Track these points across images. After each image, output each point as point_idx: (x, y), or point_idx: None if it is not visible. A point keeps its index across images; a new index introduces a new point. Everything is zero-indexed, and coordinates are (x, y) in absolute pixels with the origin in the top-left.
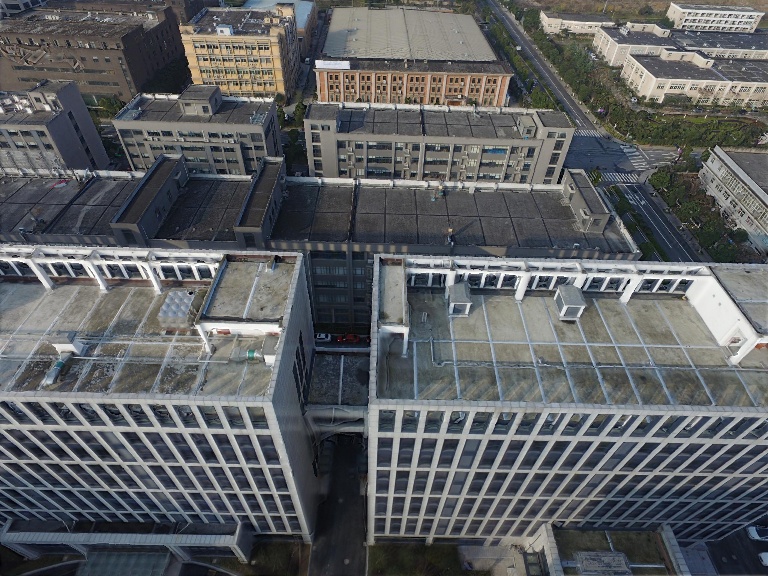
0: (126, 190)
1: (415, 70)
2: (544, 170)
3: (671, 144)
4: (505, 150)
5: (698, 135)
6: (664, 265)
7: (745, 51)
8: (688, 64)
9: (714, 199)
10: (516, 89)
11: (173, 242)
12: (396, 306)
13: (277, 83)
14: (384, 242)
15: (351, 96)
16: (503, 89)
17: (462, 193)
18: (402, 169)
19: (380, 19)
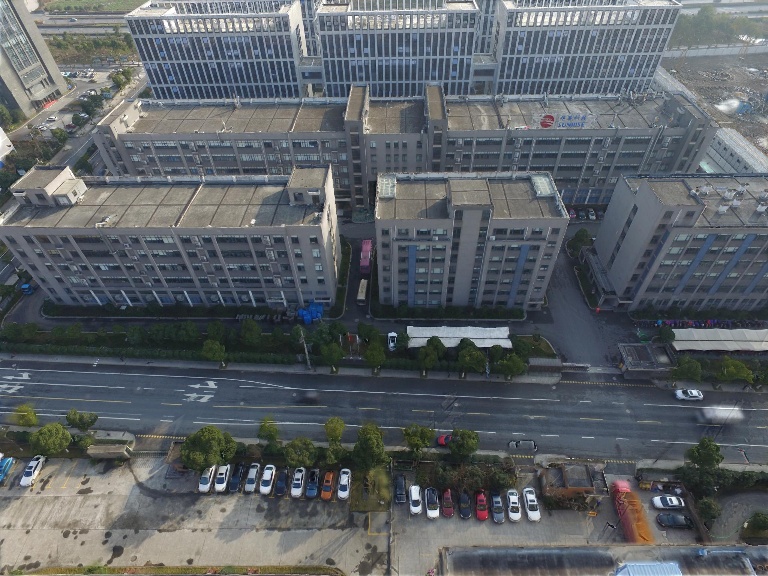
0: (469, 126)
1: None
2: None
3: None
4: None
5: None
6: None
7: None
8: None
9: None
10: None
11: (409, 98)
12: (285, 8)
13: None
14: (280, 106)
15: None
16: None
17: None
18: None
19: None
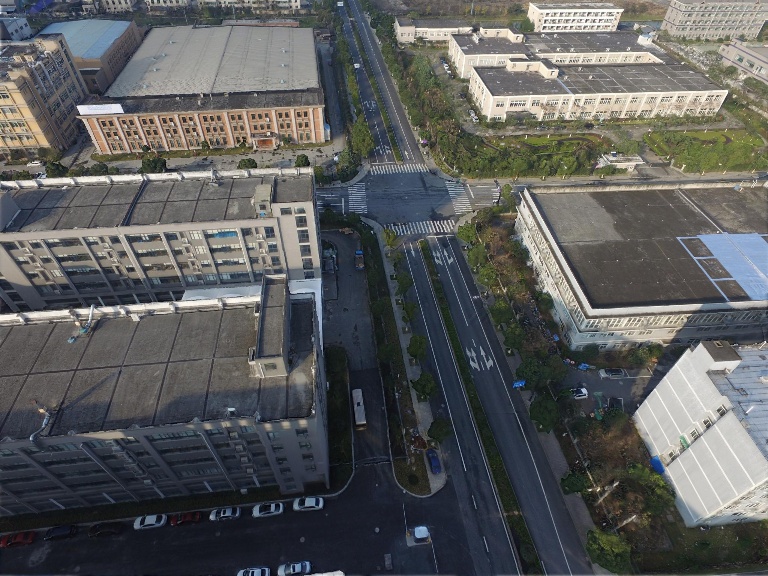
0: None
1: (210, 107)
2: (297, 249)
3: (502, 176)
4: (236, 232)
5: (526, 166)
6: None
7: (599, 54)
8: (534, 75)
9: (524, 253)
10: (347, 116)
11: None
12: None
13: (36, 135)
14: None
15: (137, 143)
16: (318, 122)
17: (123, 322)
18: (111, 265)
19: (200, 40)
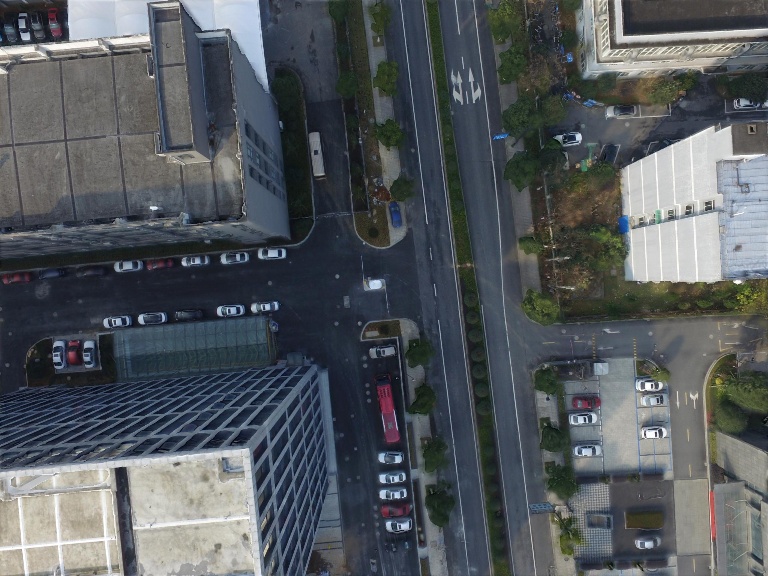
0: None
1: None
2: None
3: None
4: None
5: None
6: (49, 473)
7: None
8: None
9: None
10: None
11: None
12: None
13: None
14: None
15: None
16: None
17: None
18: None
19: None
